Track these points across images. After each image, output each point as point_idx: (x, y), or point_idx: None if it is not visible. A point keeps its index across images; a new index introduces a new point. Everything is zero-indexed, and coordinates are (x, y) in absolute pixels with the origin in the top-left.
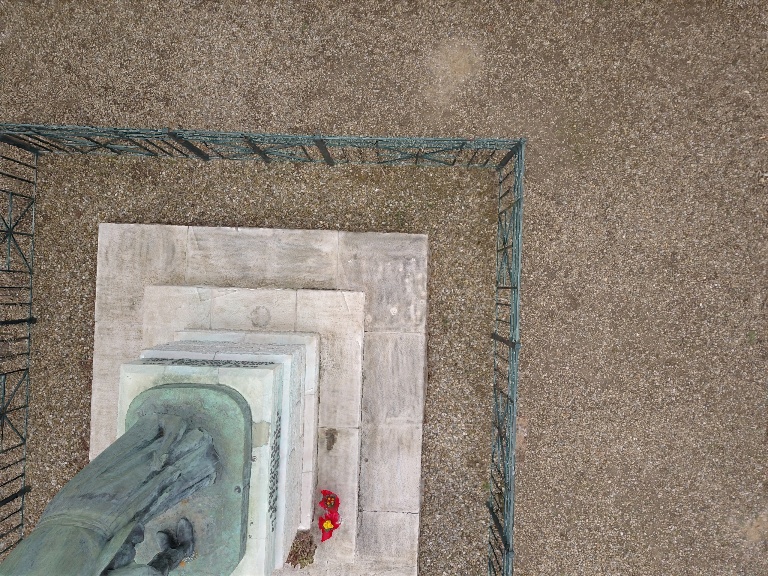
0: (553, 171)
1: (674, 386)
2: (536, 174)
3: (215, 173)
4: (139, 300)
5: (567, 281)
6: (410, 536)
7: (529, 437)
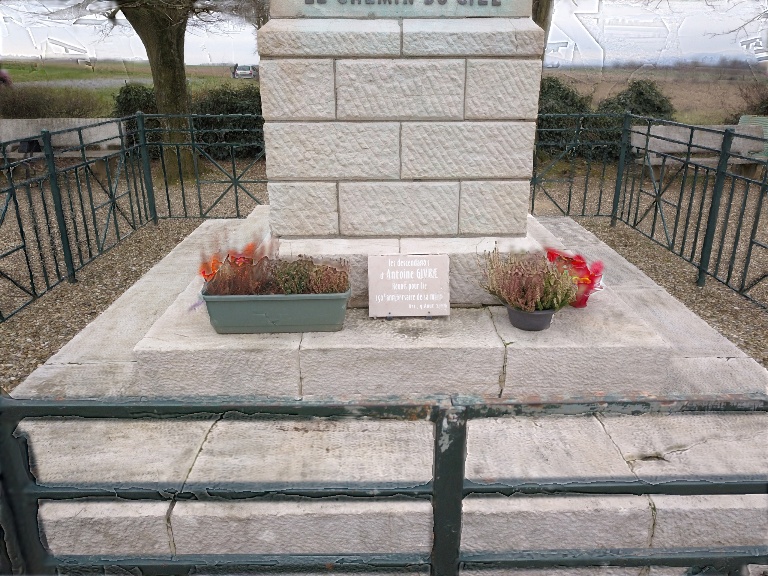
0: None
1: None
2: None
3: None
4: None
5: (749, 265)
6: (764, 382)
7: None
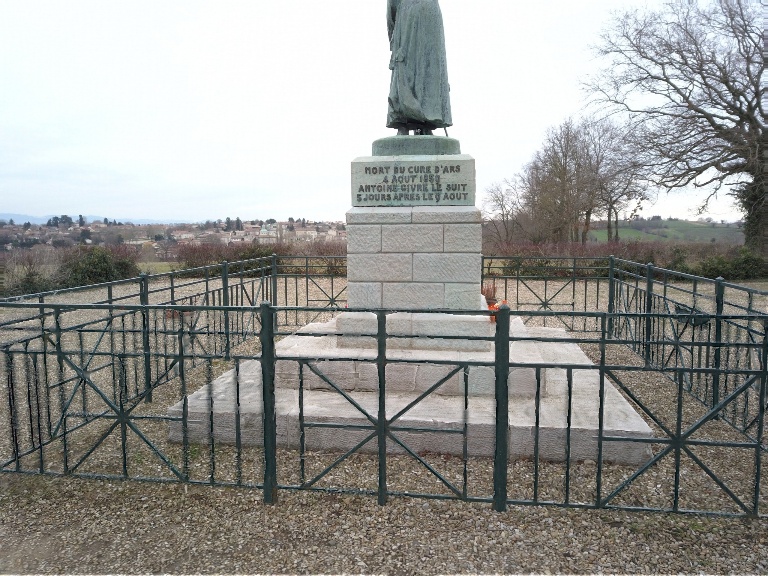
0: None
1: (2, 387)
2: None
3: None
4: None
5: None
6: None
7: None
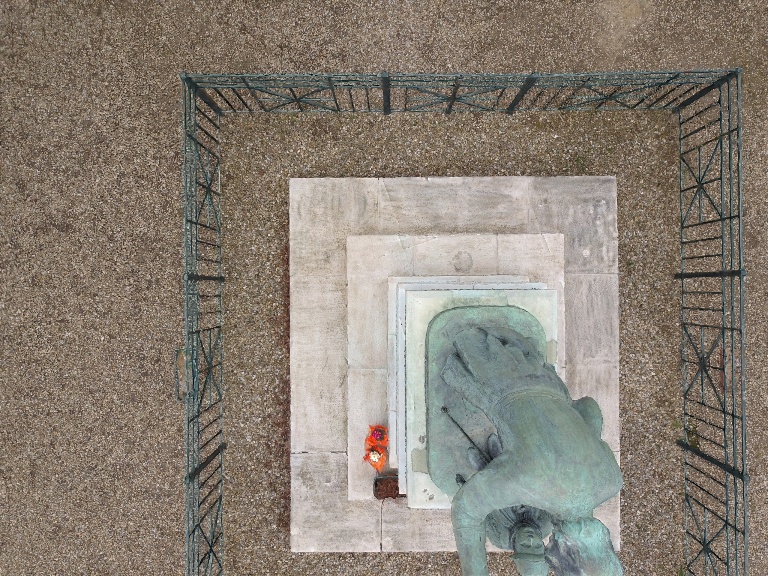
0: (727, 111)
1: None
2: (710, 115)
3: (395, 126)
4: (333, 253)
5: (746, 219)
6: None
7: (714, 375)
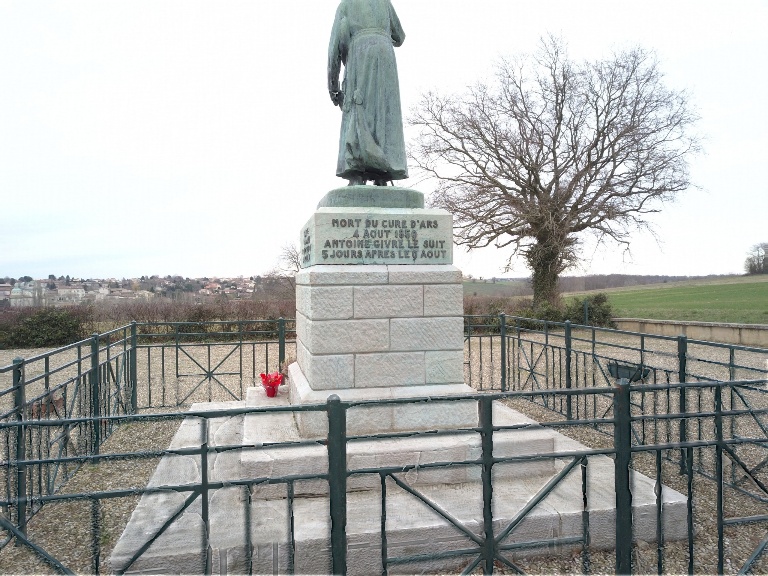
0: None
1: None
2: None
3: None
4: None
5: None
6: None
7: None
